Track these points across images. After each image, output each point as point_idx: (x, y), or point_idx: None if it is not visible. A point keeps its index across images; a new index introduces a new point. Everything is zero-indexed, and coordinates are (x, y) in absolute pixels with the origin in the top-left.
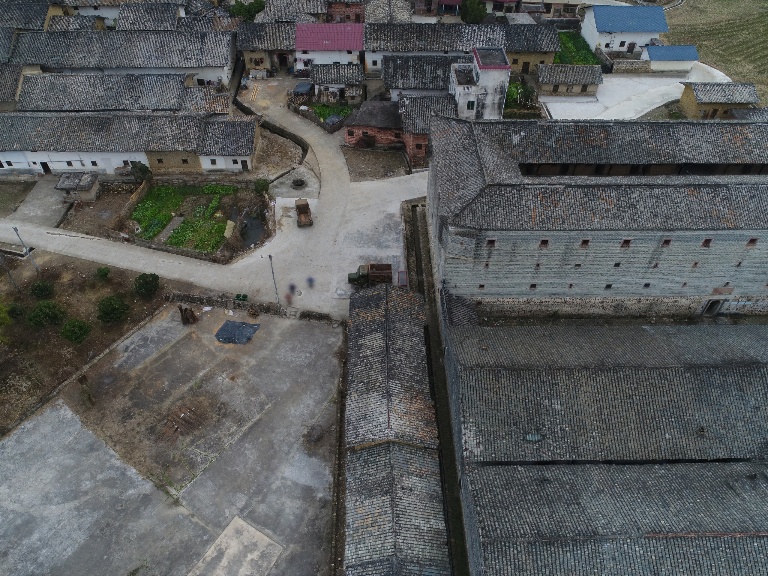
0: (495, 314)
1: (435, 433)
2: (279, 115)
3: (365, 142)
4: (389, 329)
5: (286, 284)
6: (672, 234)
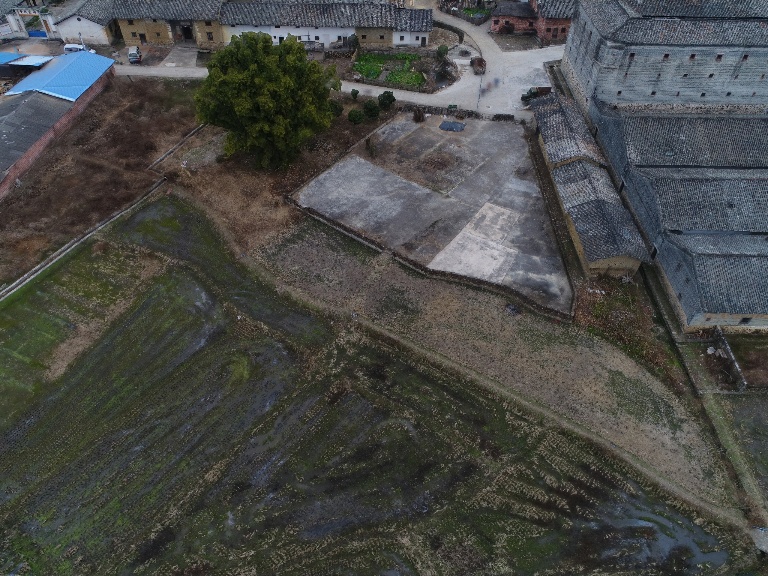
0: None
1: (604, 160)
2: (435, 15)
3: (506, 29)
4: (564, 112)
5: None
6: (750, 50)
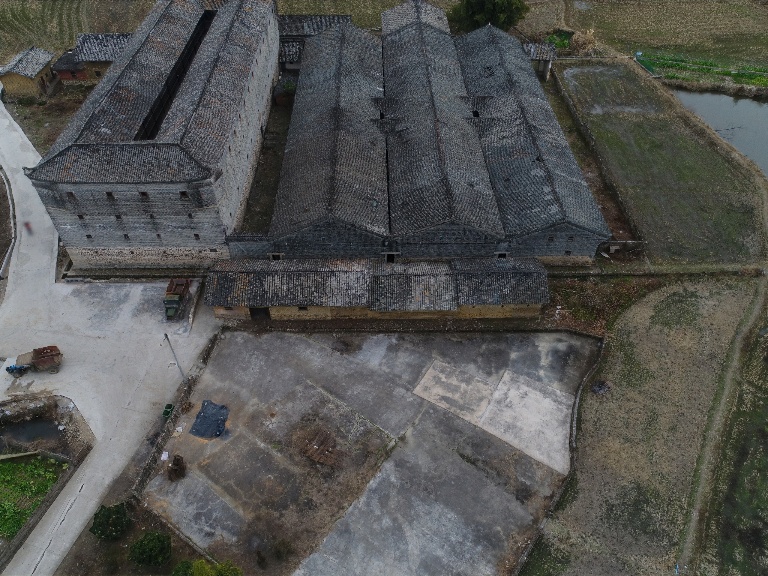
0: (239, 231)
1: None
2: None
3: None
4: None
5: (153, 378)
6: (243, 95)
